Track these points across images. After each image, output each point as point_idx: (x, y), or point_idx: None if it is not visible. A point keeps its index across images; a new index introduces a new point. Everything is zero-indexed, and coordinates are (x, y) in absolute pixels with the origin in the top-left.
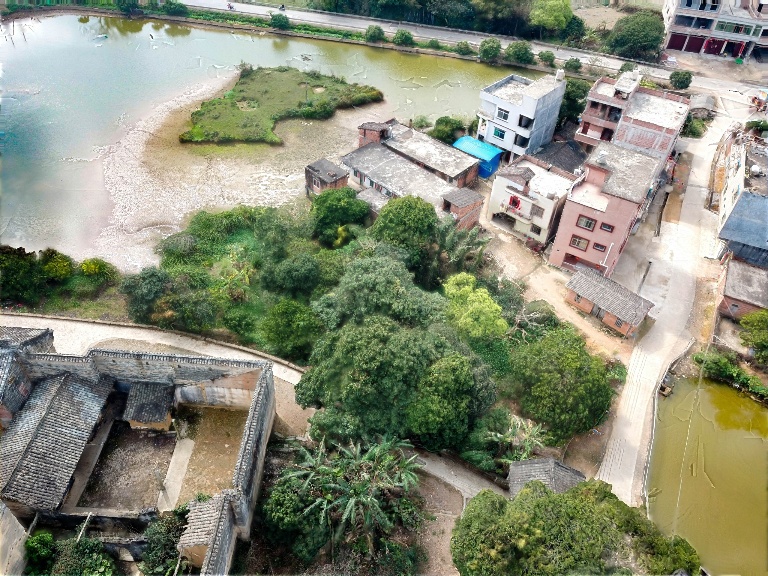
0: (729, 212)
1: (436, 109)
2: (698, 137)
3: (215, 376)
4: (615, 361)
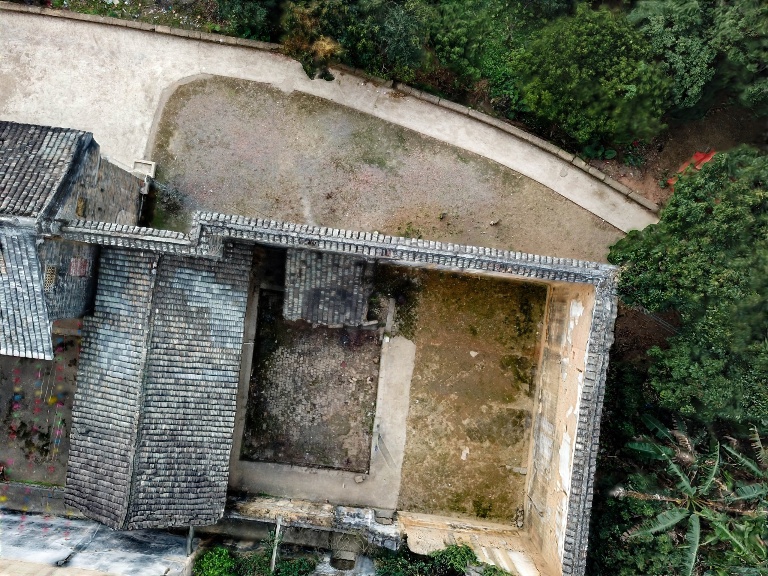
0: None
1: None
2: None
3: None
4: None
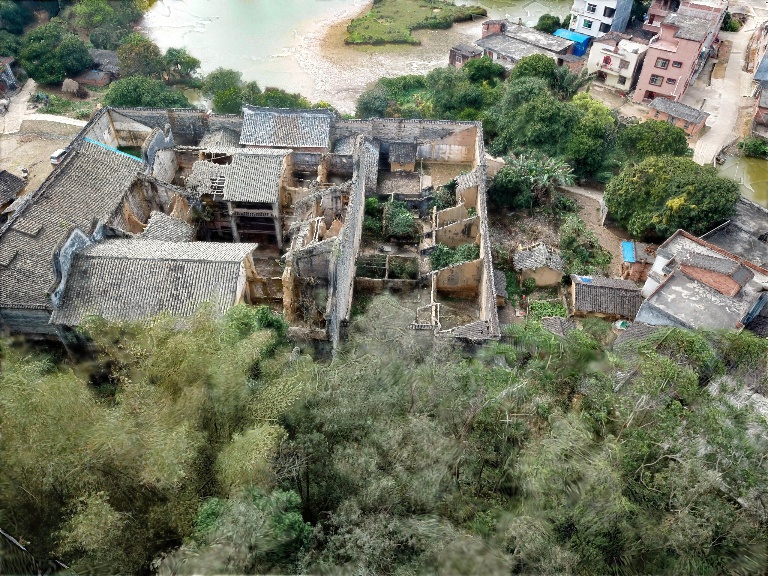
0: (761, 58)
1: (532, 18)
2: (736, 31)
3: (444, 135)
4: None
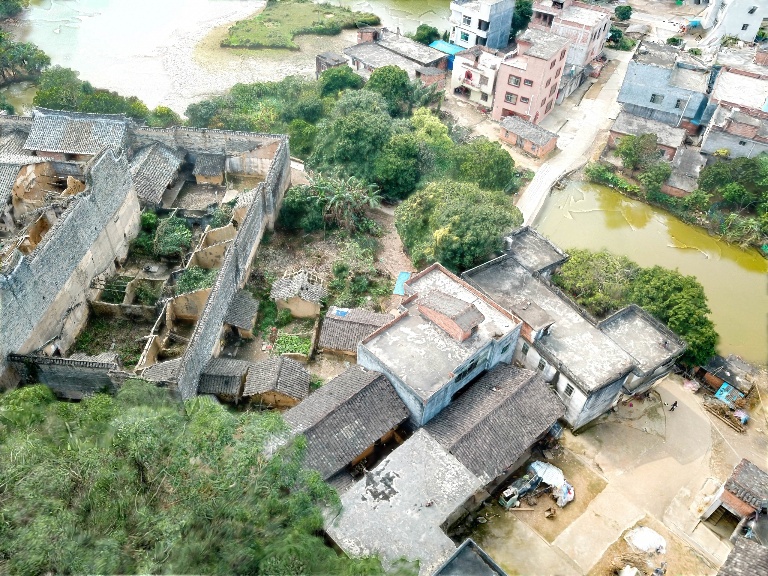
0: (623, 80)
1: None
2: (627, 50)
3: (252, 147)
4: (528, 170)
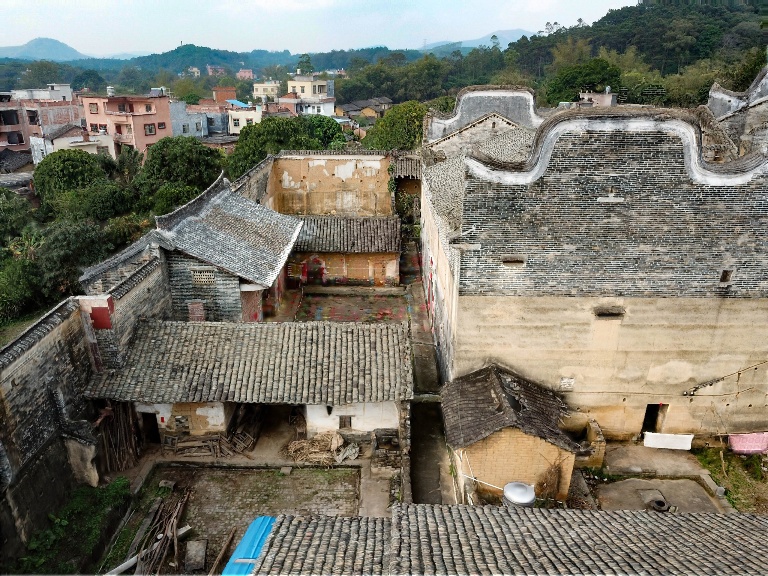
0: None
1: None
2: None
3: (265, 184)
4: None
